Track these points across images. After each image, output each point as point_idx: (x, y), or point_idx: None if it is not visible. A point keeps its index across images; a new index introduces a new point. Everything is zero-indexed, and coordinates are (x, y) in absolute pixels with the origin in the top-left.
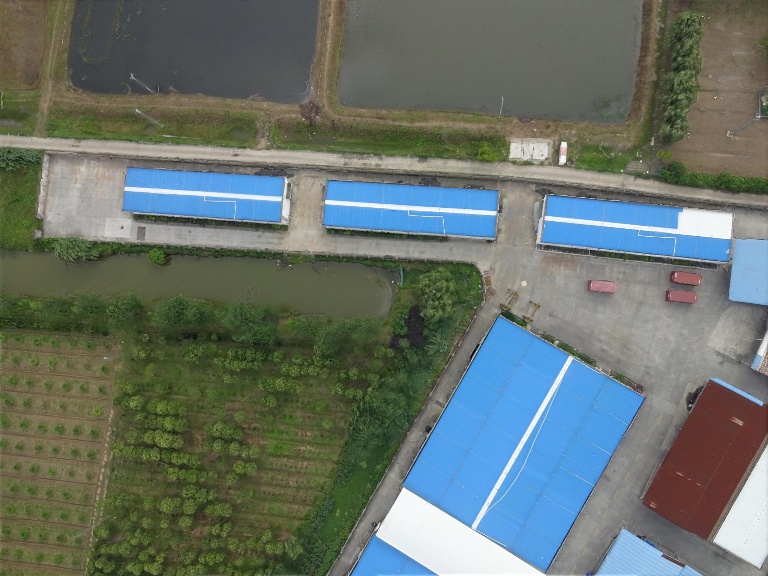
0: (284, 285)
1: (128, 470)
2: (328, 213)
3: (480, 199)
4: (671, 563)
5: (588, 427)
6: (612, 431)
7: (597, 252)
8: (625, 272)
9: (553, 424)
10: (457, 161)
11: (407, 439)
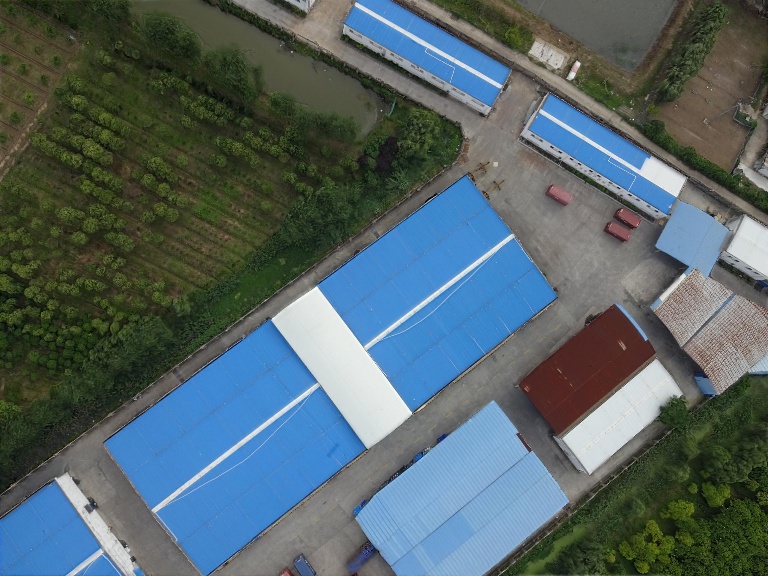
0: (279, 65)
1: (36, 169)
2: (353, 15)
3: (493, 69)
4: (521, 444)
5: (501, 302)
6: (519, 314)
7: (567, 165)
8: (582, 193)
9: (473, 287)
10: (484, 34)
11: (334, 254)
